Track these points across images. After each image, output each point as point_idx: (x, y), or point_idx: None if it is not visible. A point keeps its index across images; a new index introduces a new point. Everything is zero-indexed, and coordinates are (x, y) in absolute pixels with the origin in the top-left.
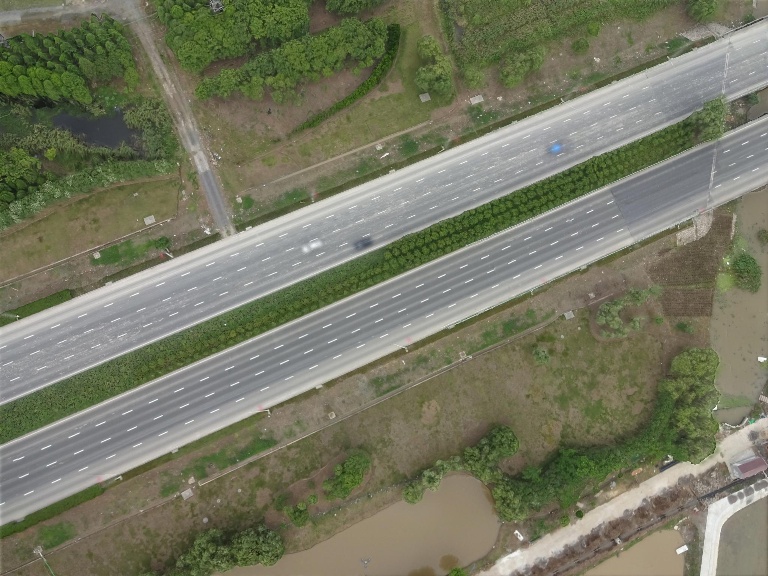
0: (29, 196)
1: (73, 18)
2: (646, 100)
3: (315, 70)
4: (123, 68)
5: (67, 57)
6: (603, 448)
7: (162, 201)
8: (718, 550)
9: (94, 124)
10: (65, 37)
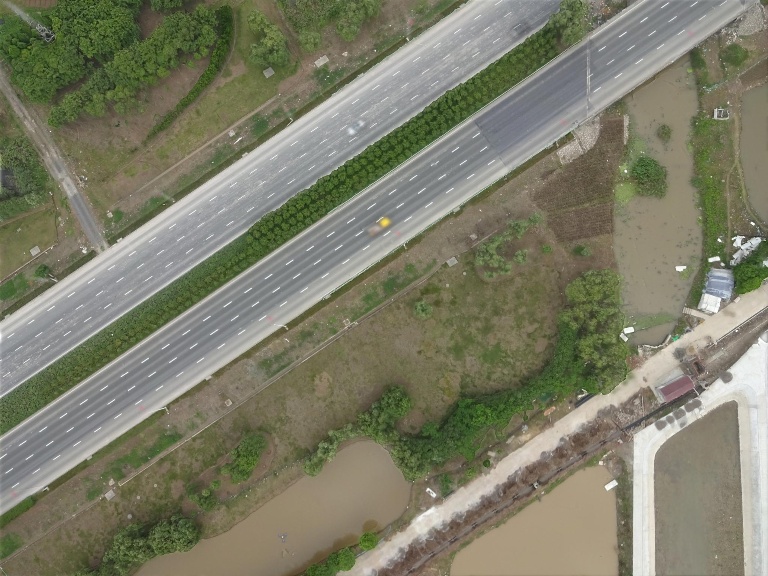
0: None
1: None
2: (501, 16)
3: (151, 73)
4: None
5: None
6: (503, 393)
7: (43, 231)
8: (654, 480)
9: None
10: None
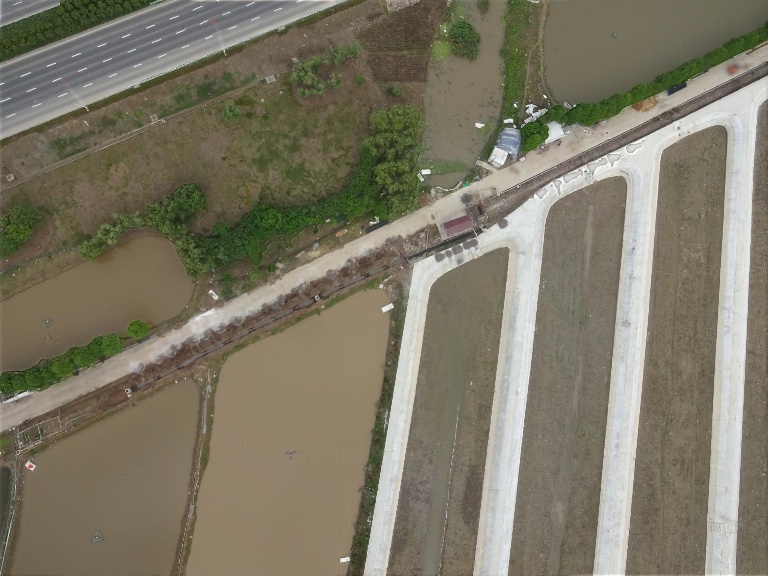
0: None
1: None
2: None
3: None
4: None
5: None
6: None
7: None
8: (427, 309)
9: None
10: None
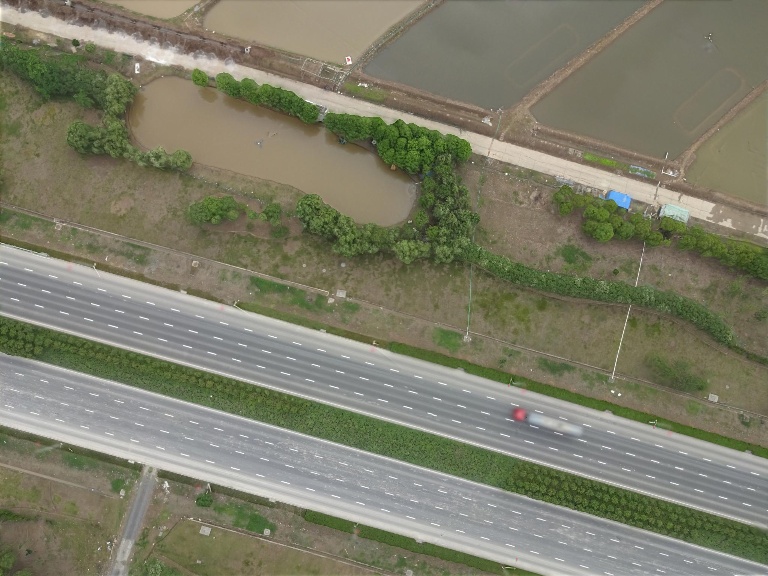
0: None
1: None
2: None
3: None
4: None
5: None
6: None
7: (183, 540)
8: None
9: None
10: None
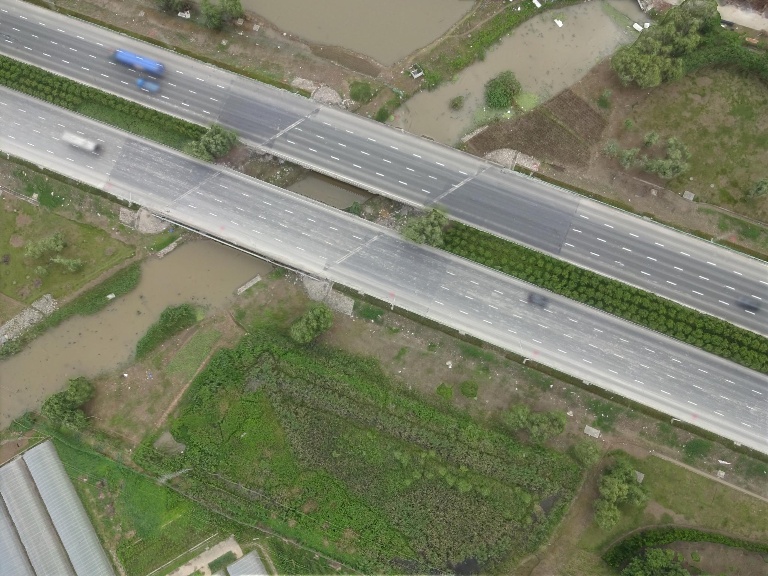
0: None
1: None
2: (450, 293)
3: None
4: None
5: None
6: None
7: None
8: None
9: None
10: None
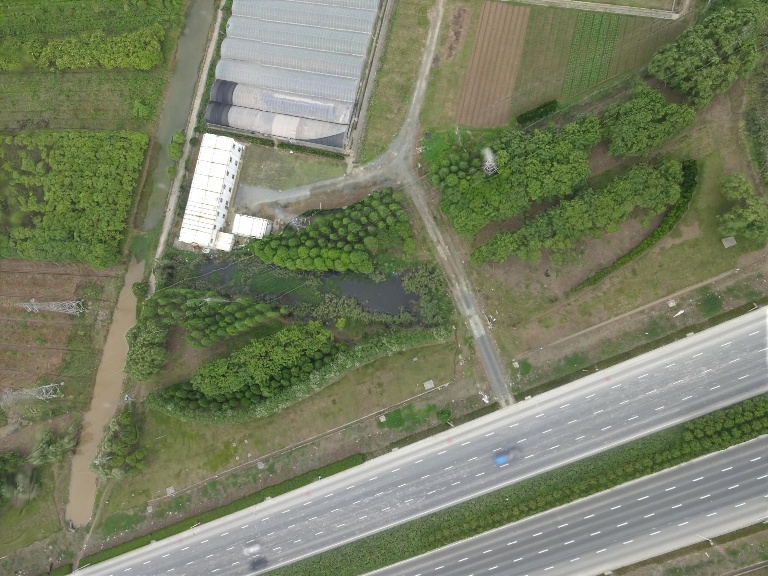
0: (325, 367)
1: (354, 187)
2: None
3: (598, 227)
4: (402, 240)
5: (354, 236)
6: None
7: (440, 366)
8: None
9: (375, 290)
10: (351, 217)
